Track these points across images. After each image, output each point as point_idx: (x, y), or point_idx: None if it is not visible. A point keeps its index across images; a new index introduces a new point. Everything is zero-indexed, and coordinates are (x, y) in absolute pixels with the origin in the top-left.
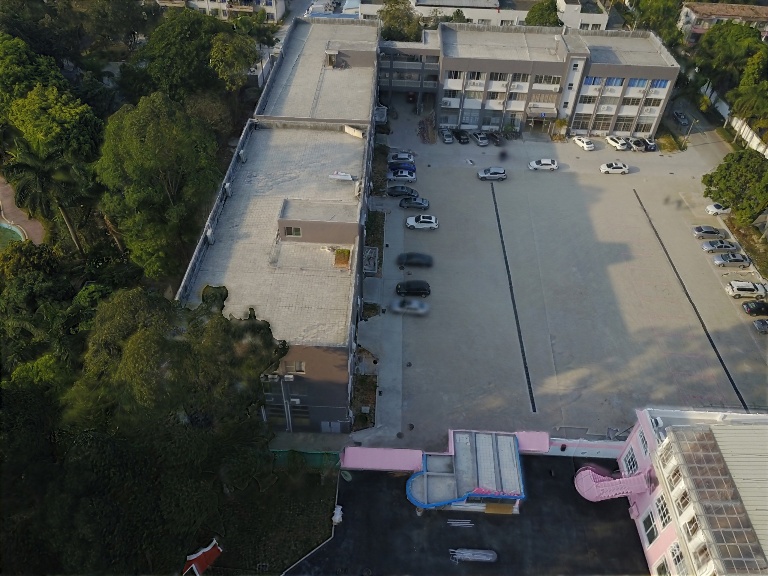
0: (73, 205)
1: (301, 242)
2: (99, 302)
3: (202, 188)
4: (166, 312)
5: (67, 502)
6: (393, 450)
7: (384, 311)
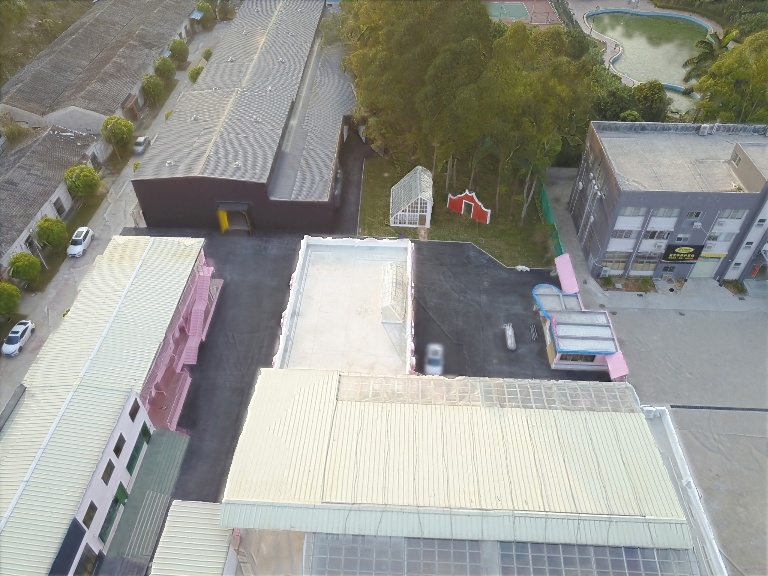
0: (696, 78)
1: (734, 173)
2: (627, 121)
3: (765, 122)
4: (556, 48)
5: (446, 47)
6: (574, 276)
7: (742, 299)
